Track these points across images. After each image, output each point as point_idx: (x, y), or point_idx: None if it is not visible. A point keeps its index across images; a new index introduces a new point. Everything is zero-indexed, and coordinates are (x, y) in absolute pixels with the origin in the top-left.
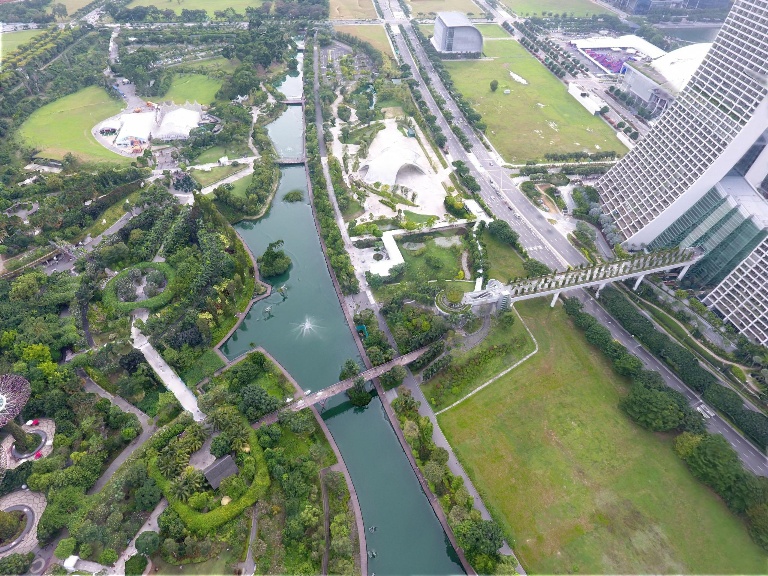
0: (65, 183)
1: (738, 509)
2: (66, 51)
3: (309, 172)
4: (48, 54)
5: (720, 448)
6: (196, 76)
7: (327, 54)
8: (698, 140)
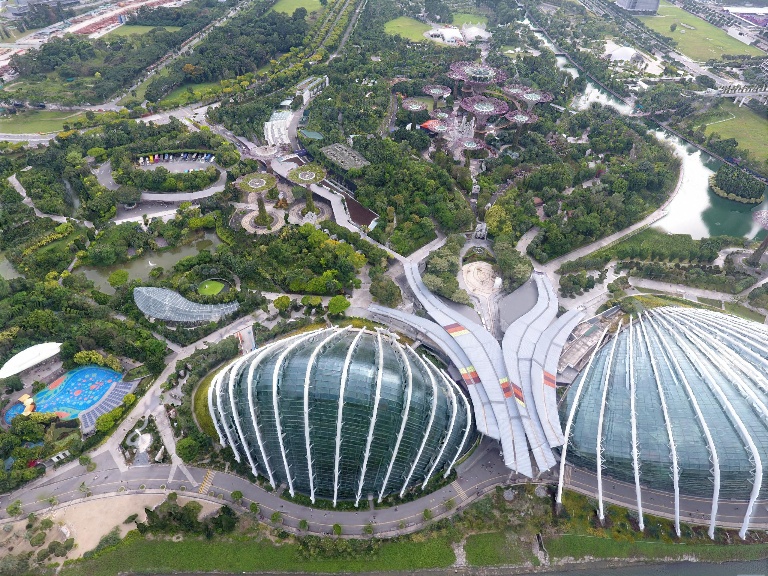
0: None
1: None
2: None
3: (571, 58)
4: None
5: None
6: (465, 14)
7: (541, 9)
8: None
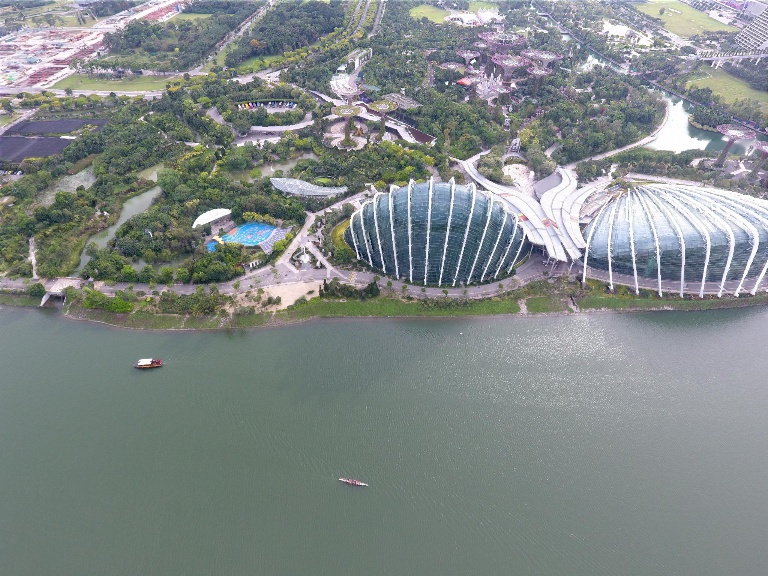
0: None
1: None
2: None
3: (574, 35)
4: None
5: None
6: (479, 2)
7: None
8: None
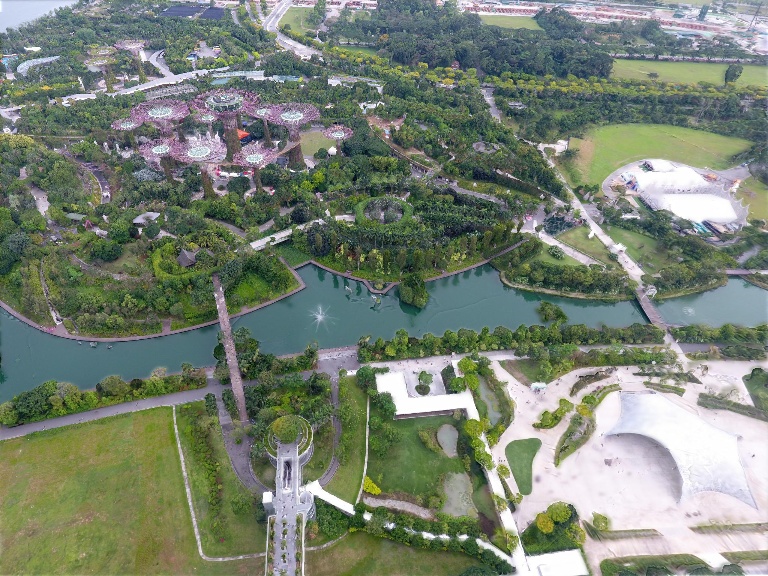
0: (527, 157)
1: None
2: None
3: None
4: None
5: None
6: None
7: None
8: None
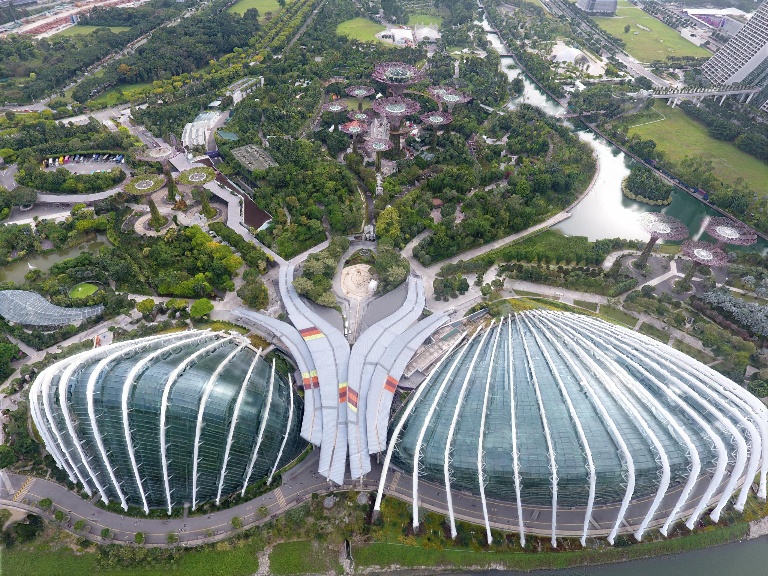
0: None
1: (760, 154)
2: (324, 1)
3: (517, 59)
4: (319, 0)
5: (755, 135)
6: (422, 15)
7: (501, 10)
8: (765, 29)
